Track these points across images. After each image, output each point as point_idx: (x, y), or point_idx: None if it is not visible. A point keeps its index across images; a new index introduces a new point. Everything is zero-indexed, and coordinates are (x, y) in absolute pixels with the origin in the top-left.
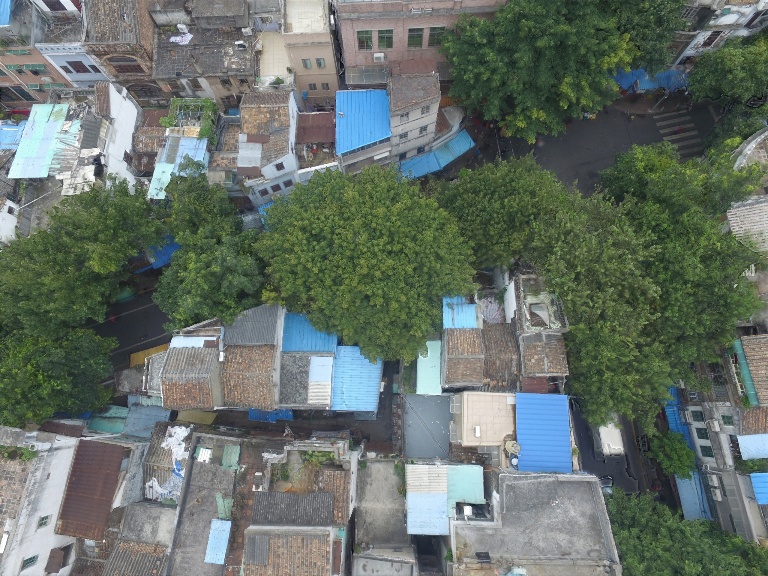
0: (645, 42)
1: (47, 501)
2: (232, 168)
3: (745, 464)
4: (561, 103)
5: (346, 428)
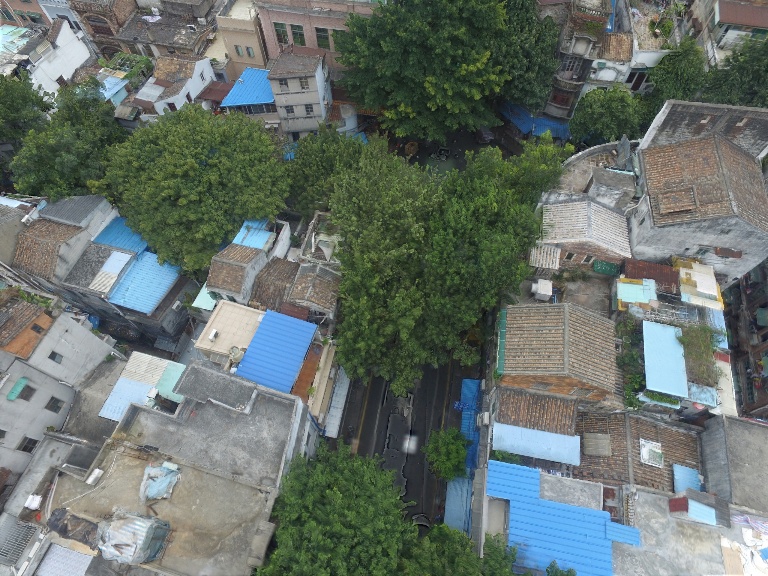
0: (515, 70)
1: None
2: (139, 106)
3: (494, 455)
4: (428, 104)
5: None
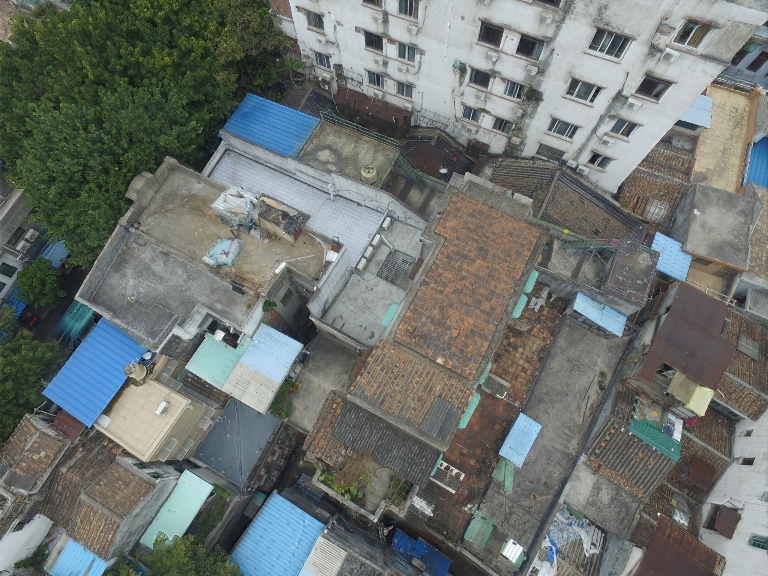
0: None
1: None
2: None
3: None
4: None
5: None
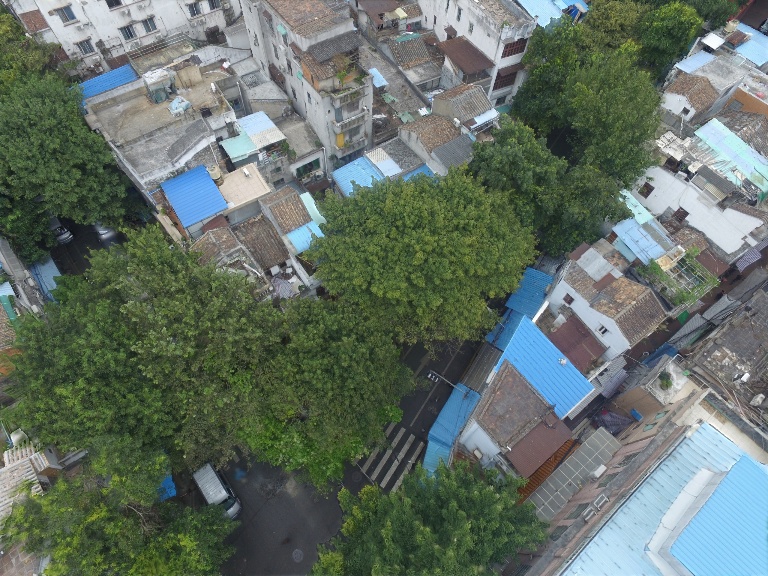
0: None
1: (478, 33)
2: None
3: (6, 280)
4: None
5: None
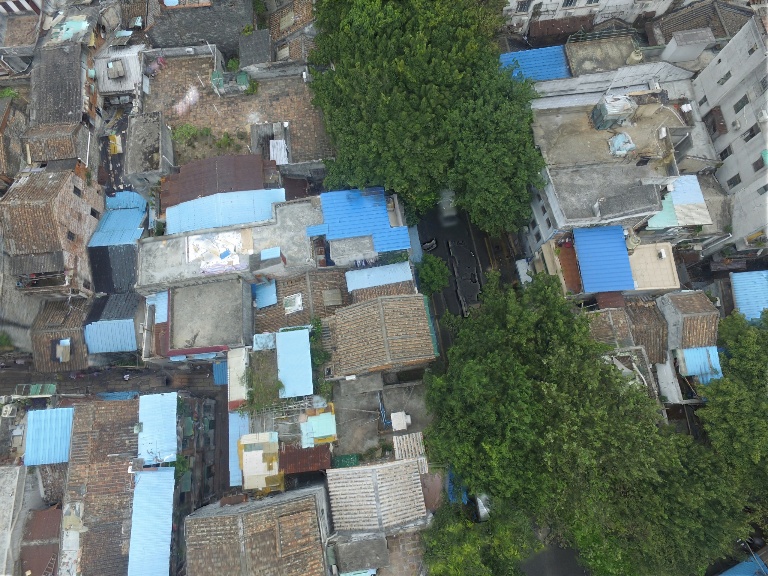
0: None
1: None
2: None
3: None
4: None
5: (701, 278)
